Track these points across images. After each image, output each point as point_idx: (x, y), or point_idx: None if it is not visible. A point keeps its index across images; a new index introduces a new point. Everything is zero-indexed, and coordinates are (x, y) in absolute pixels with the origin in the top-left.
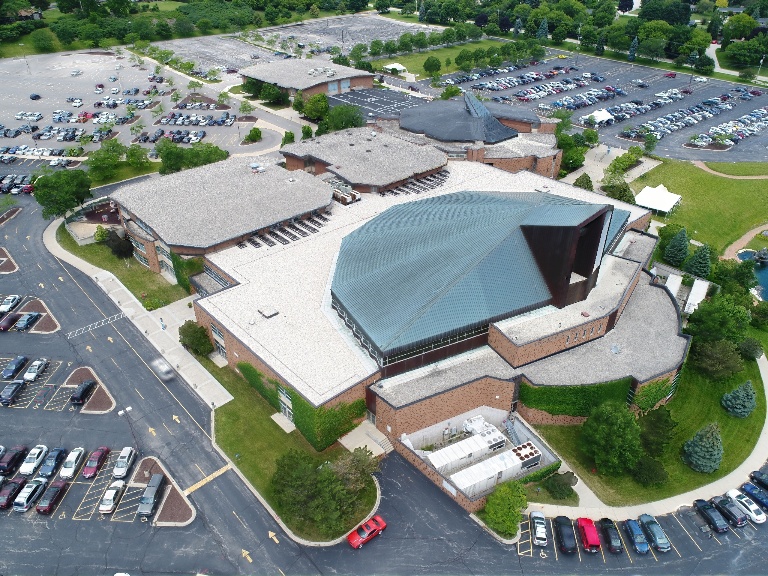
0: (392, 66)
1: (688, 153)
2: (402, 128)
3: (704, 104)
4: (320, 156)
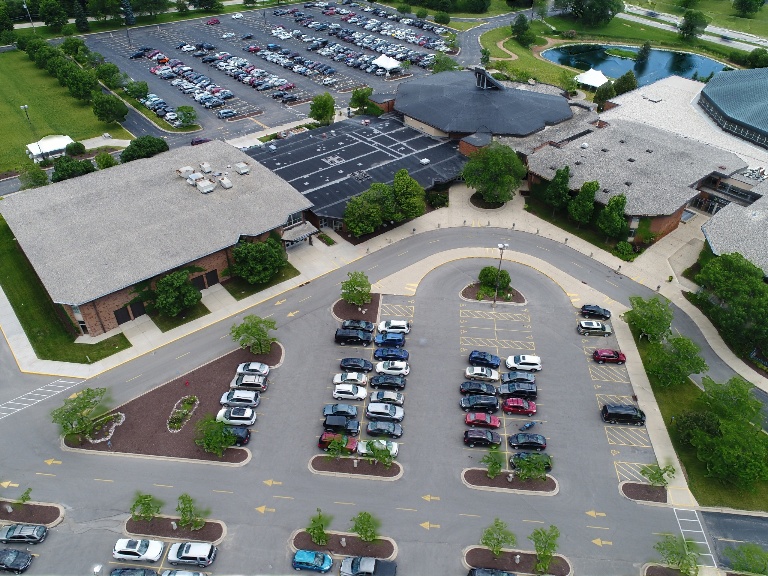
0: (49, 144)
1: (471, 57)
2: (527, 135)
3: (322, 30)
4: (691, 179)
